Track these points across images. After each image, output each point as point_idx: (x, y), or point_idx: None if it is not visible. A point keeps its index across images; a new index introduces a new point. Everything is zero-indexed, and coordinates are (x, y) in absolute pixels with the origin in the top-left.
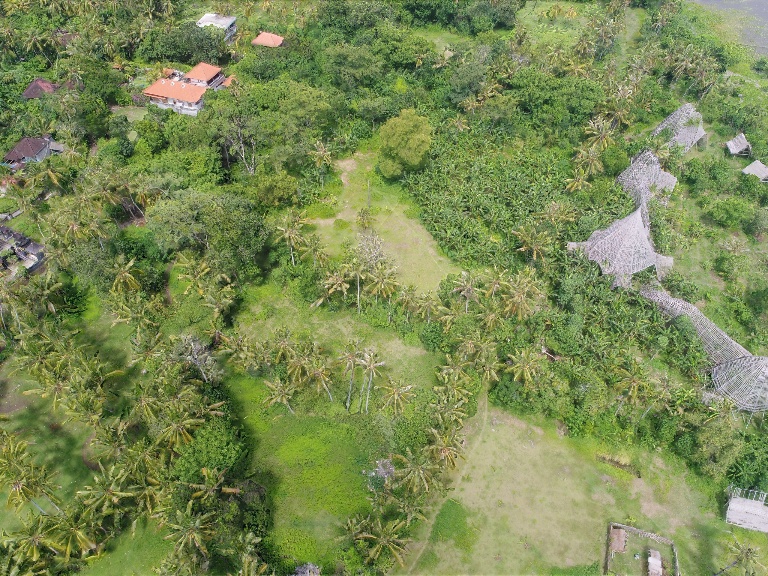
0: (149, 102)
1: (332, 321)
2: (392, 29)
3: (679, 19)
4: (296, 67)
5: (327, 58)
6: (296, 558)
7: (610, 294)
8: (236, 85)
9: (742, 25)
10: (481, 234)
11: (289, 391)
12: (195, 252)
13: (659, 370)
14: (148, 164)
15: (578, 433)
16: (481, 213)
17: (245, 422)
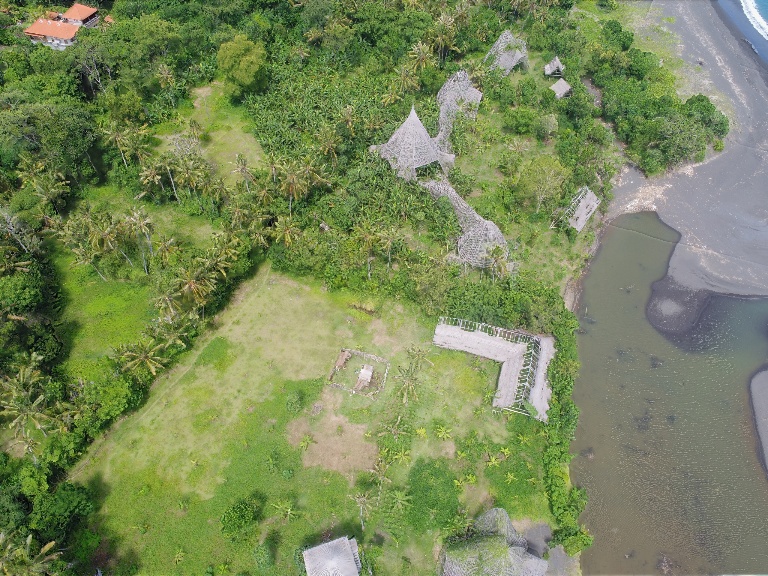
0: (30, 41)
1: (156, 213)
2: None
3: None
4: (167, 7)
5: None
6: None
7: (391, 183)
8: (104, 22)
9: None
10: None
11: (91, 256)
12: (33, 154)
13: (424, 243)
14: (6, 86)
15: (332, 285)
16: (306, 126)
17: (63, 287)
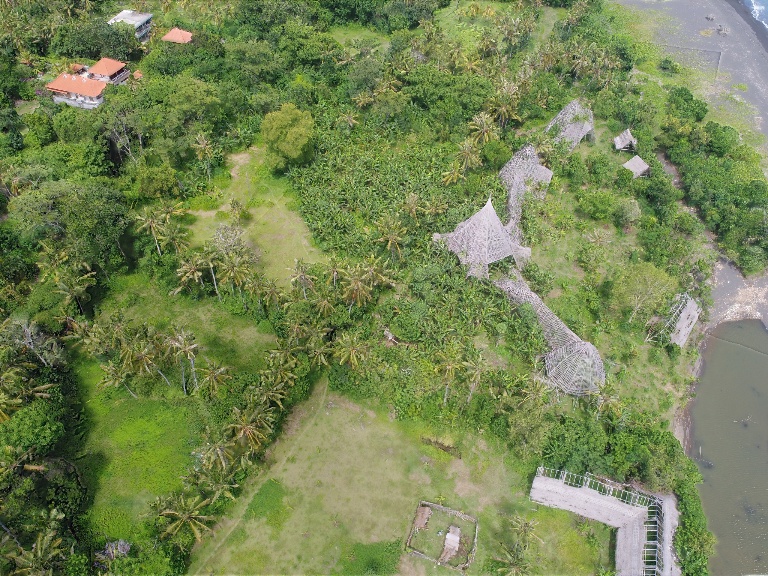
0: (52, 96)
1: (193, 309)
2: (298, 26)
3: (596, 19)
4: (201, 63)
5: (228, 54)
6: (108, 535)
7: (462, 283)
8: (134, 80)
9: (658, 25)
10: (357, 226)
11: (122, 375)
12: (55, 241)
13: (502, 356)
14: (26, 156)
15: (404, 416)
16: (358, 205)
17: (87, 406)
